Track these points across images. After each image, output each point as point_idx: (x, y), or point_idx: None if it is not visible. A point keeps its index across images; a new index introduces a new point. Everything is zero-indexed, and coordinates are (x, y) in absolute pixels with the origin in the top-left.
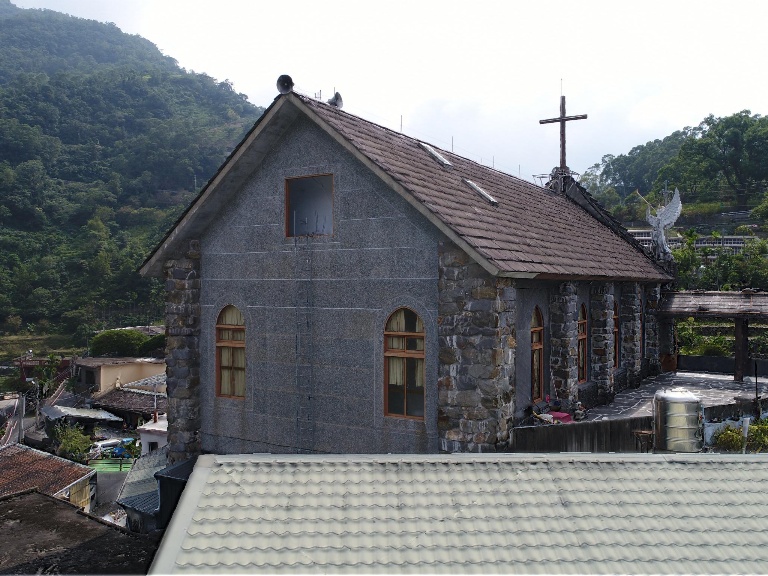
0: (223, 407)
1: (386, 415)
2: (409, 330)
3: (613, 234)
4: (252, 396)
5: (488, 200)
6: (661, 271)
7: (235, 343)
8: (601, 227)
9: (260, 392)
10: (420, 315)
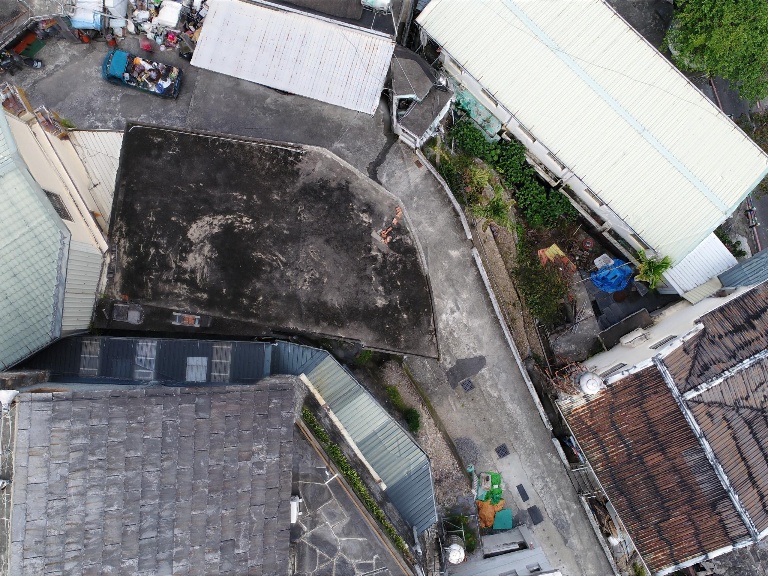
0: None
1: None
2: None
3: None
4: None
5: None
6: None
7: None
8: None
9: None
10: None
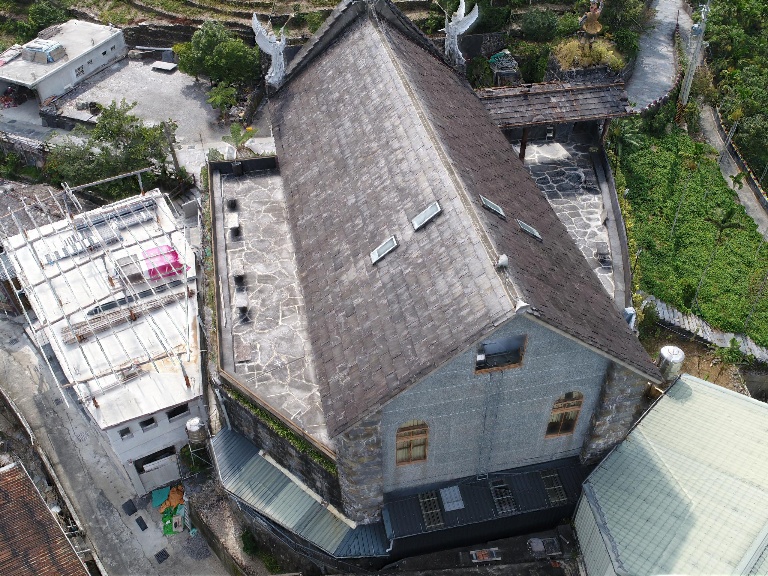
0: (404, 470)
1: (546, 438)
2: (570, 399)
3: (427, 55)
4: (434, 458)
5: (541, 240)
6: (467, 85)
7: (416, 437)
8: (424, 56)
9: (442, 455)
10: (583, 393)
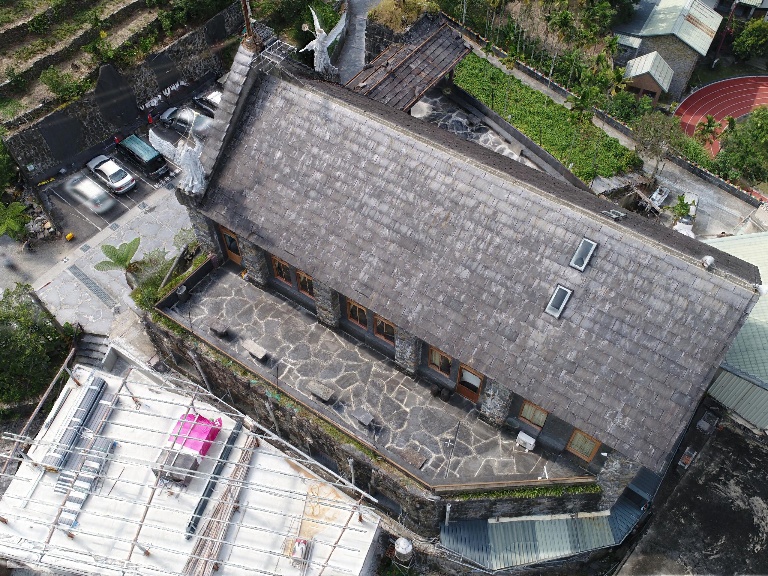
0: None
1: None
2: None
3: None
4: None
5: None
6: None
7: None
8: None
9: None
10: None
